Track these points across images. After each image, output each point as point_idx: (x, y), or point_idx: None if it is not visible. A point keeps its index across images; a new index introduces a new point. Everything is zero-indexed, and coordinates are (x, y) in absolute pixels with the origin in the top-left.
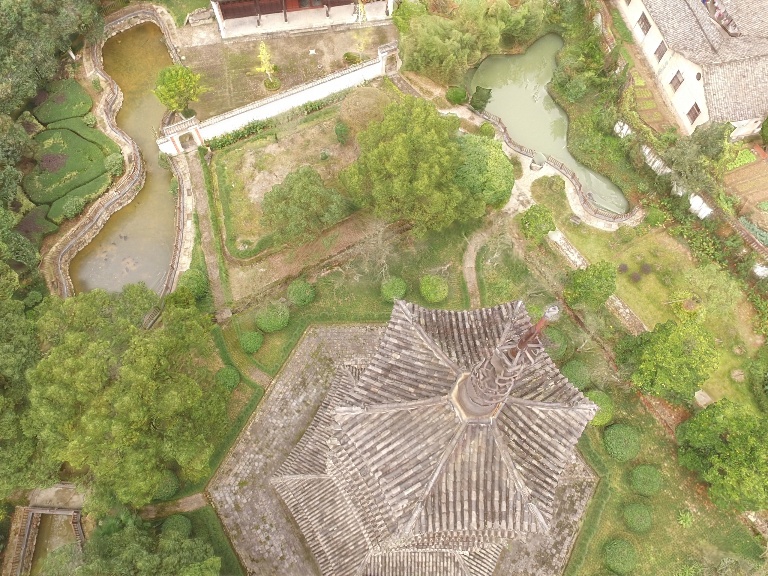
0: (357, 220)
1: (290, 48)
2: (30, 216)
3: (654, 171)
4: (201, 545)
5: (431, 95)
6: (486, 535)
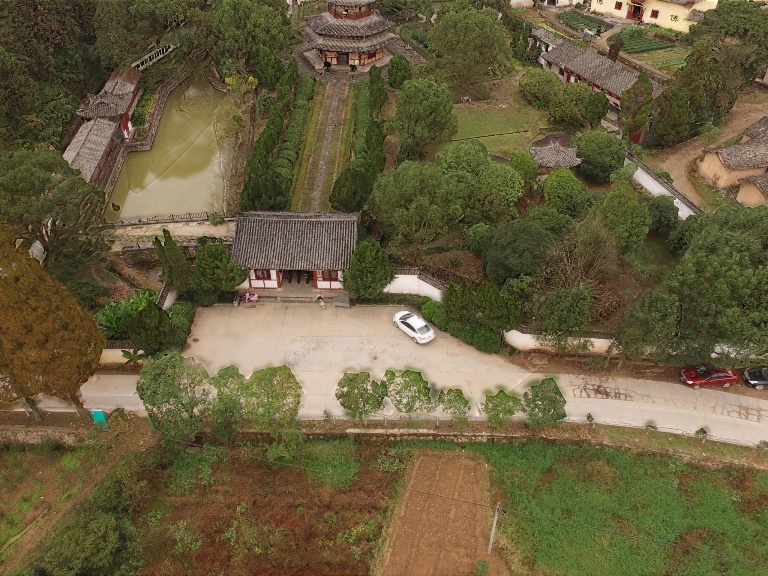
0: None
1: None
2: None
3: None
4: None
5: None
6: None
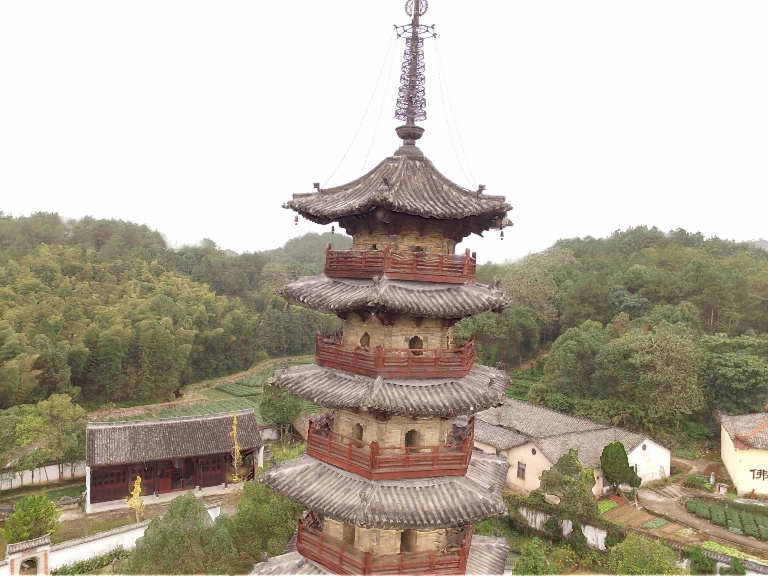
0: None
1: (160, 513)
2: None
3: (540, 531)
4: None
5: None
6: (467, 309)
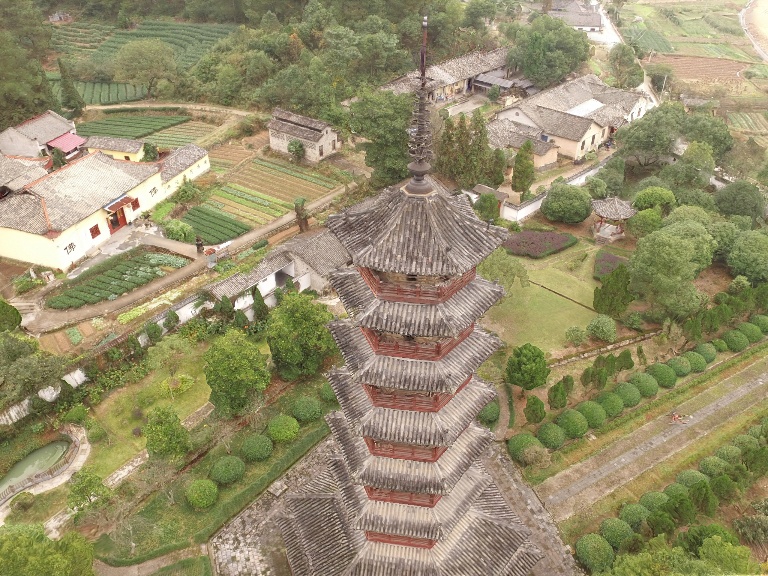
0: None
1: None
2: None
3: (18, 421)
4: None
5: None
6: None
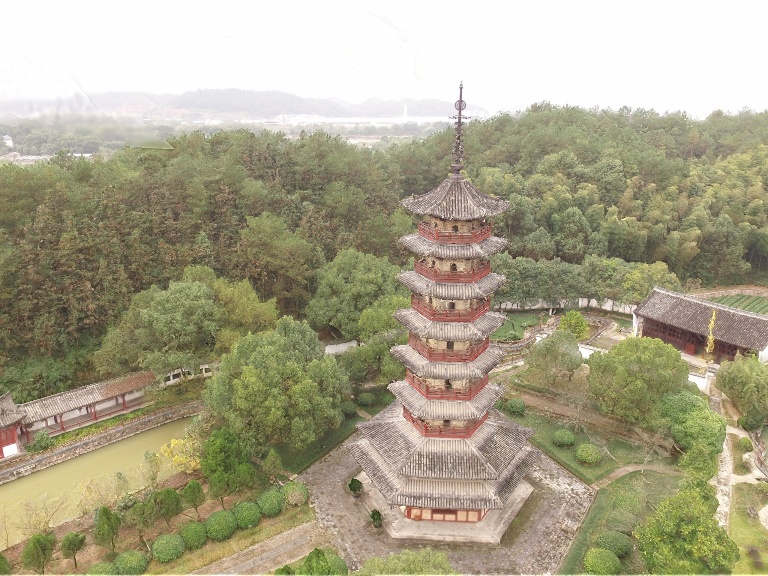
0: (590, 413)
1: None
2: None
3: None
4: (349, 386)
5: (730, 417)
6: None
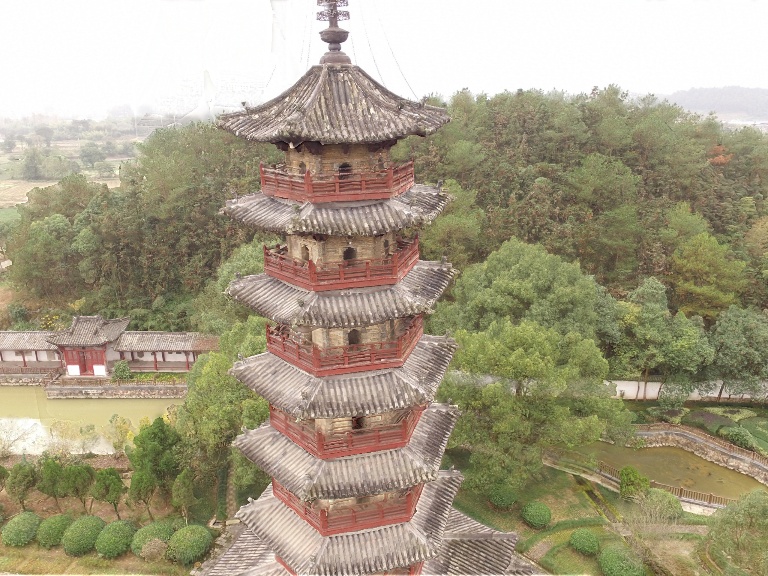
0: None
1: None
2: (721, 417)
3: None
4: None
5: None
6: None
